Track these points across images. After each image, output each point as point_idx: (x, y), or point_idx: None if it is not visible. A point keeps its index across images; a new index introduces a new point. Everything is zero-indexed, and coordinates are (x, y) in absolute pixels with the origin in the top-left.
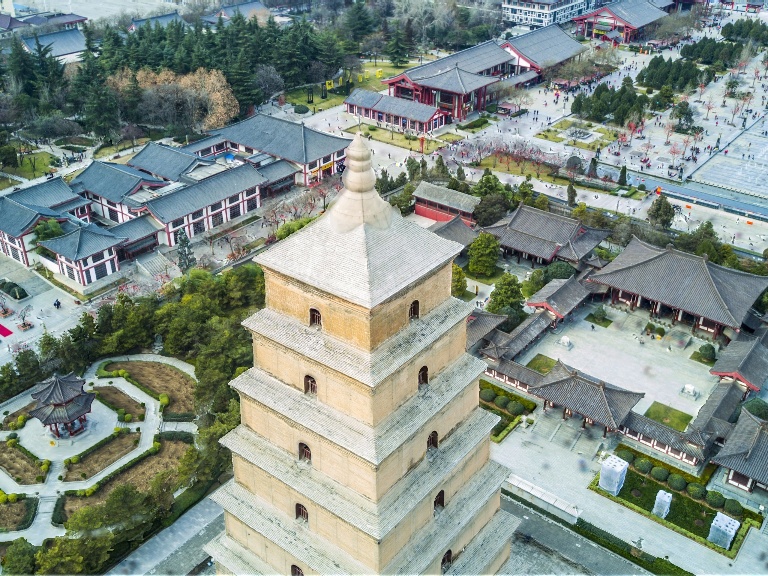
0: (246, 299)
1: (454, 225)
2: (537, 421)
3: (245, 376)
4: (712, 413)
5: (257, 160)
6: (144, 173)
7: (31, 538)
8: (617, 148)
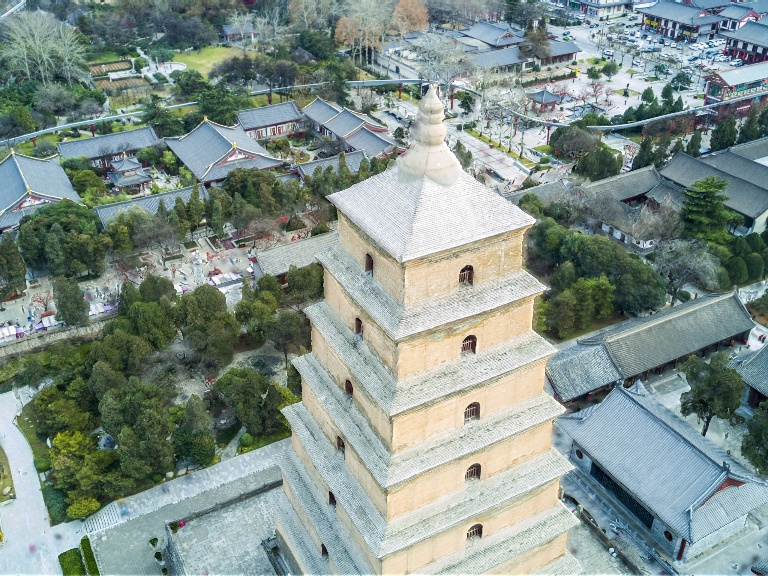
0: None
1: None
2: None
3: None
4: None
5: None
6: None
7: None
8: None
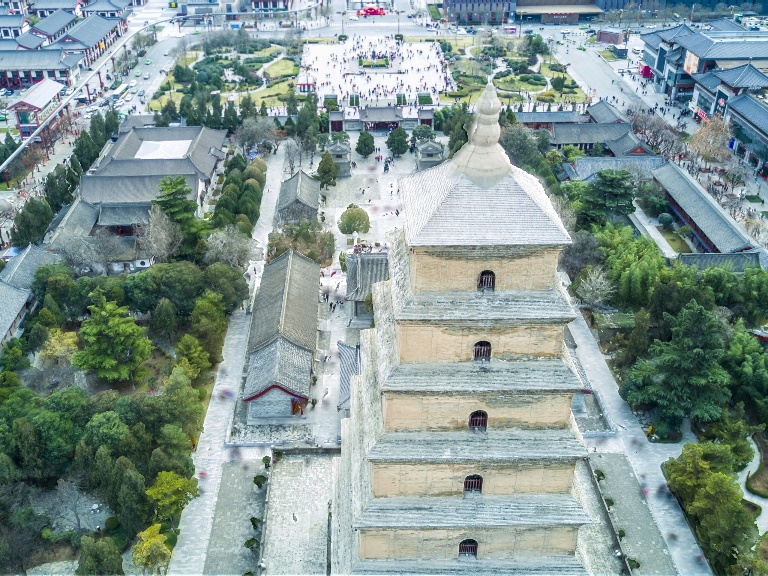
0: None
1: None
2: None
3: None
4: None
5: None
6: None
7: None
8: None
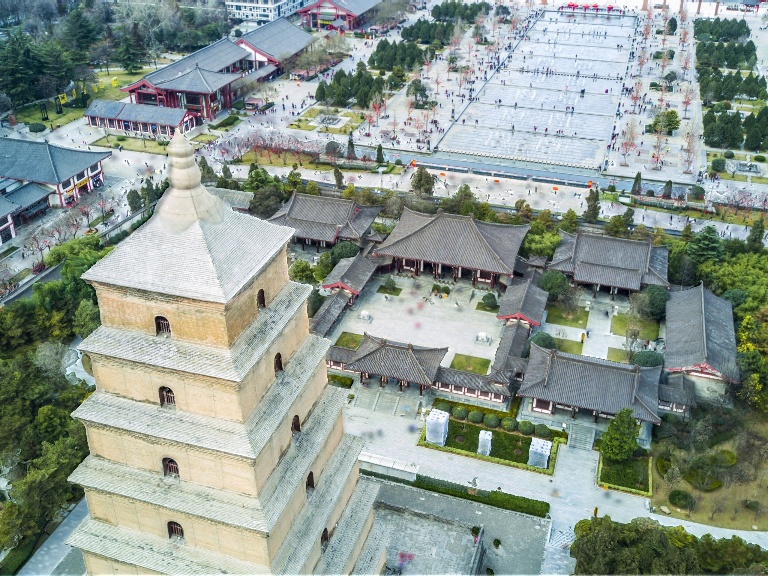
0: (28, 335)
1: None
2: (357, 395)
3: (89, 403)
4: (507, 353)
5: (1, 187)
6: None
7: None
8: (367, 129)
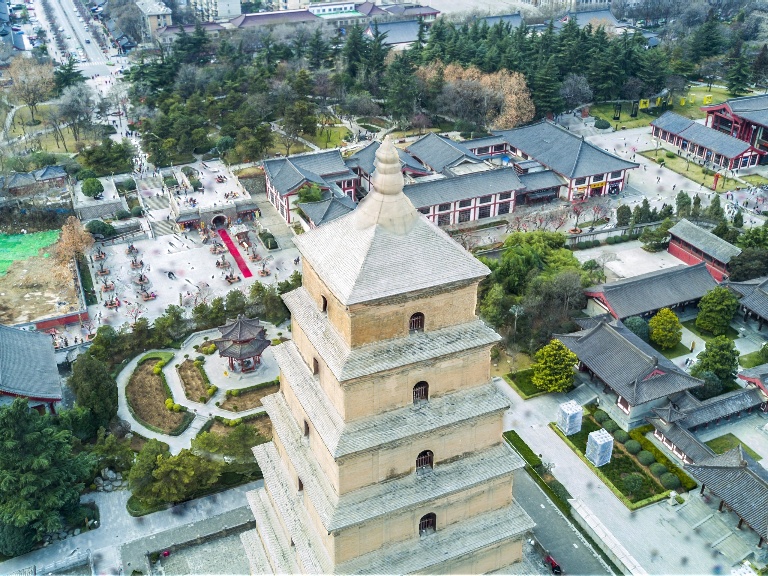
0: None
1: (695, 271)
2: (688, 502)
3: (282, 345)
4: None
5: (526, 166)
6: (415, 160)
7: (176, 445)
8: None
